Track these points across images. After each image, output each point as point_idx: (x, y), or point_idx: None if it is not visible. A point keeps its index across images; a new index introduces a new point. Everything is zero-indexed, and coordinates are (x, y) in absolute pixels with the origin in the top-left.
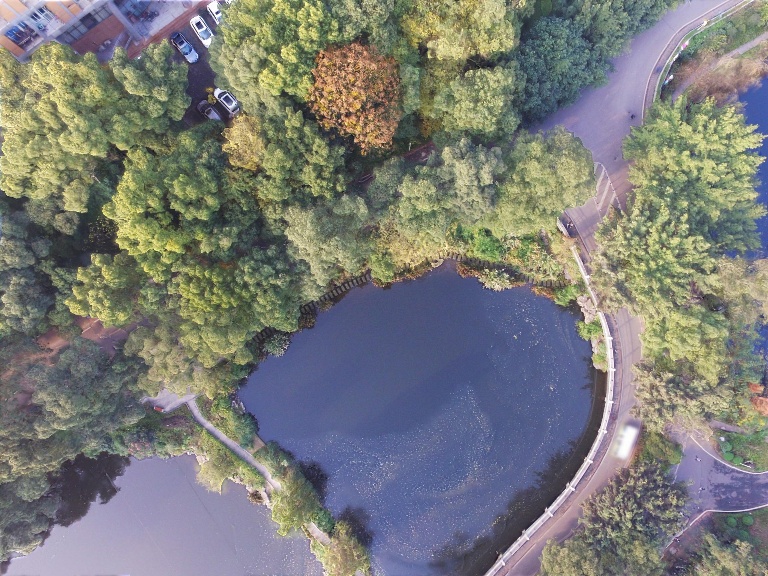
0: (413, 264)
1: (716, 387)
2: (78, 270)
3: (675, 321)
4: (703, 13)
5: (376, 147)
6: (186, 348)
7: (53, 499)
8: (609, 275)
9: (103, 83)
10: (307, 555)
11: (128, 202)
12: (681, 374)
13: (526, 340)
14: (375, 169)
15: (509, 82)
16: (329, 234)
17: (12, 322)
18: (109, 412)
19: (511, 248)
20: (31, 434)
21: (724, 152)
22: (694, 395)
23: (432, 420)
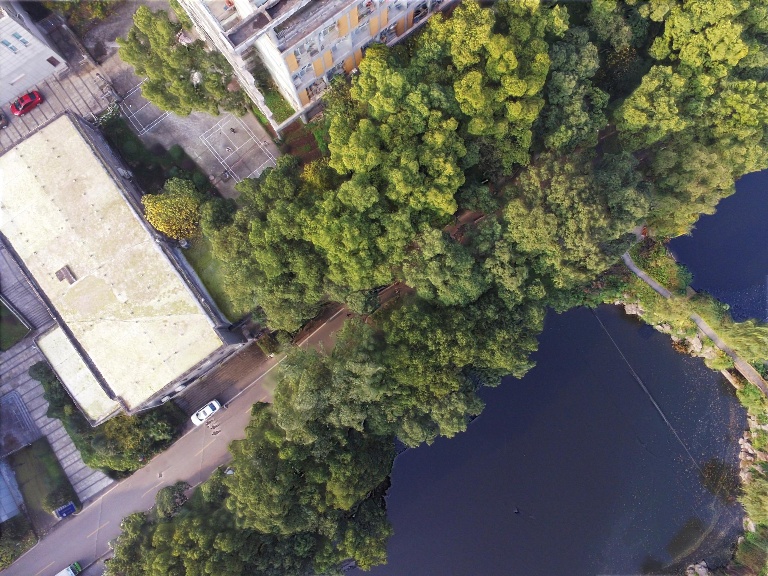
0: None
1: None
2: (647, 78)
3: None
4: None
5: None
6: (728, 161)
7: None
8: None
9: None
10: (732, 402)
11: (729, 3)
12: None
13: None
14: None
15: None
16: None
17: (576, 130)
18: None
19: None
20: (609, 233)
21: None
22: None
23: None
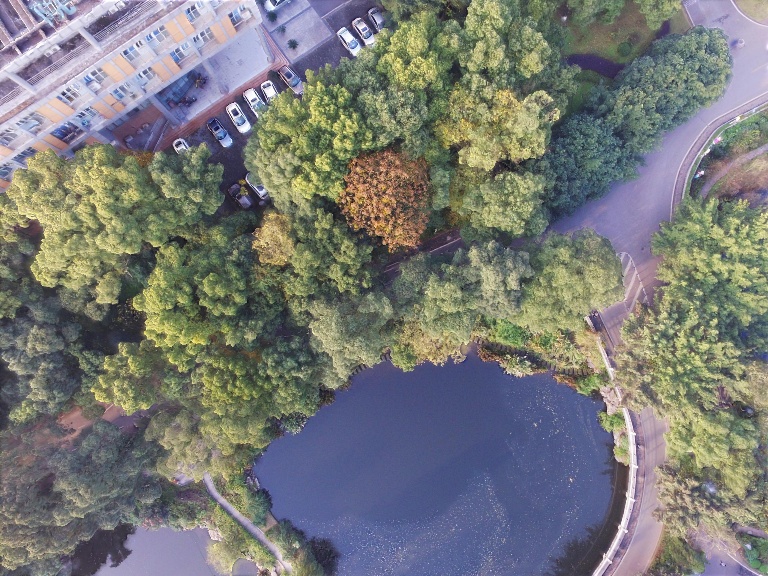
0: (436, 361)
1: (744, 500)
2: (105, 359)
3: (702, 428)
4: (736, 107)
5: (403, 245)
6: (206, 438)
7: (65, 571)
8: (634, 374)
9: (141, 185)
10: None
11: (158, 300)
12: (707, 482)
13: (546, 428)
14: (401, 264)
15: (539, 188)
16: (353, 332)
17: (38, 406)
18: (126, 493)
19: (534, 334)
20: (50, 522)
21: (756, 255)
22: (721, 506)
23: (447, 506)
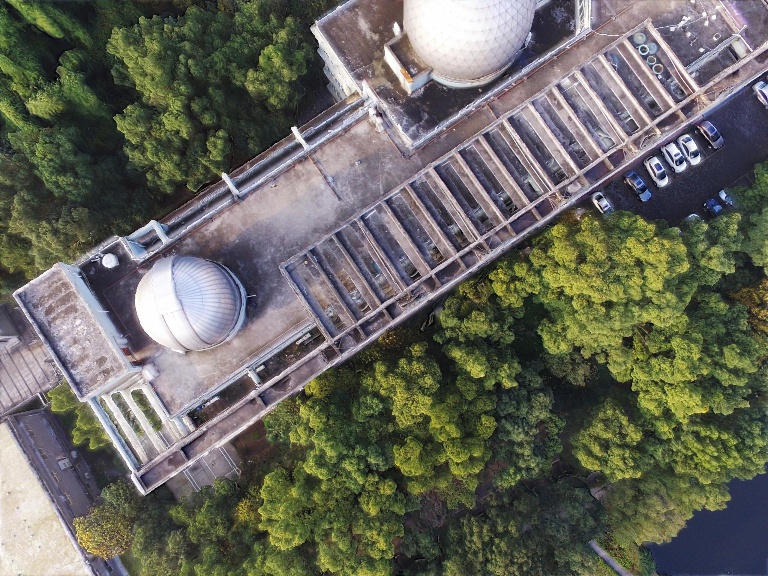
0: None
1: None
2: (602, 427)
3: None
4: None
5: None
6: (687, 506)
7: None
8: None
9: None
10: None
11: (688, 372)
12: None
13: None
14: None
15: None
16: None
17: (526, 473)
18: None
19: None
20: None
21: None
22: None
23: None
